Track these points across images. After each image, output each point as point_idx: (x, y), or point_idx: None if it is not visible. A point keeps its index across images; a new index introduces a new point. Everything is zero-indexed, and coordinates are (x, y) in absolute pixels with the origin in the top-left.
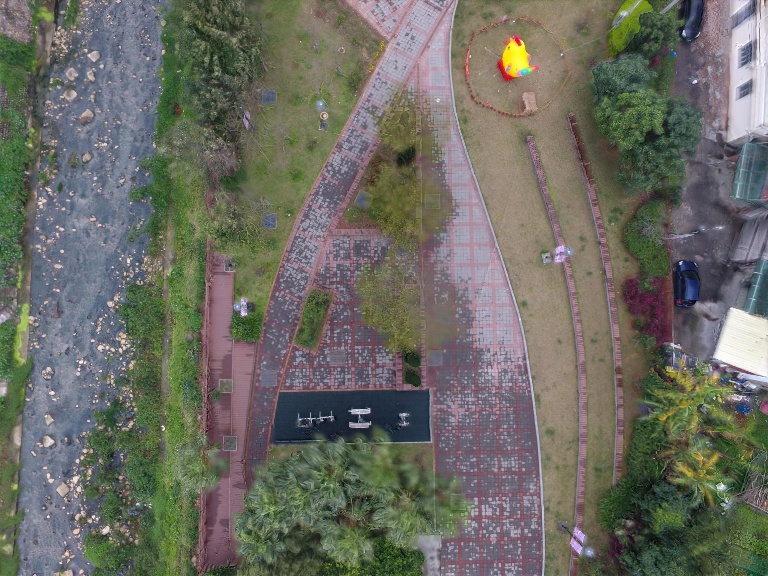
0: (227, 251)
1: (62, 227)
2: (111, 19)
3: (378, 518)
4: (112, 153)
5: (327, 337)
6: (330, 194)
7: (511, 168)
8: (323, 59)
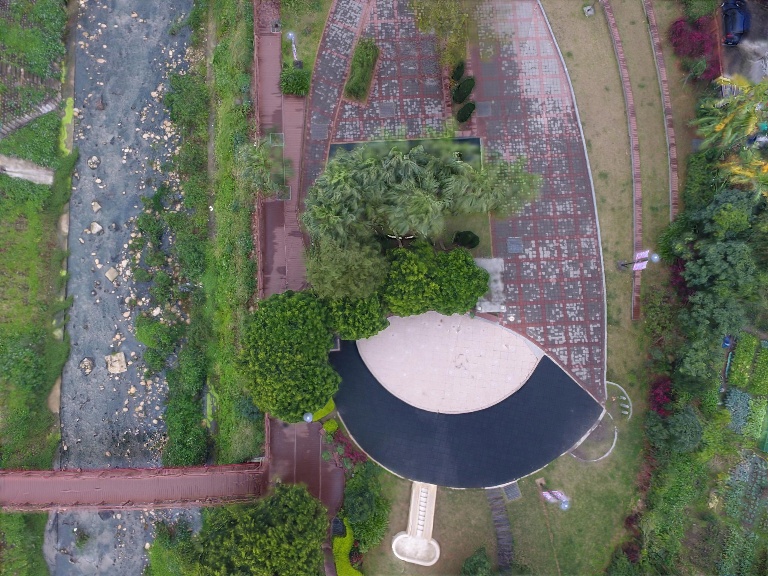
0: (272, 13)
1: (104, 24)
2: None
3: (448, 189)
4: None
5: (375, 91)
6: None
7: None
8: None
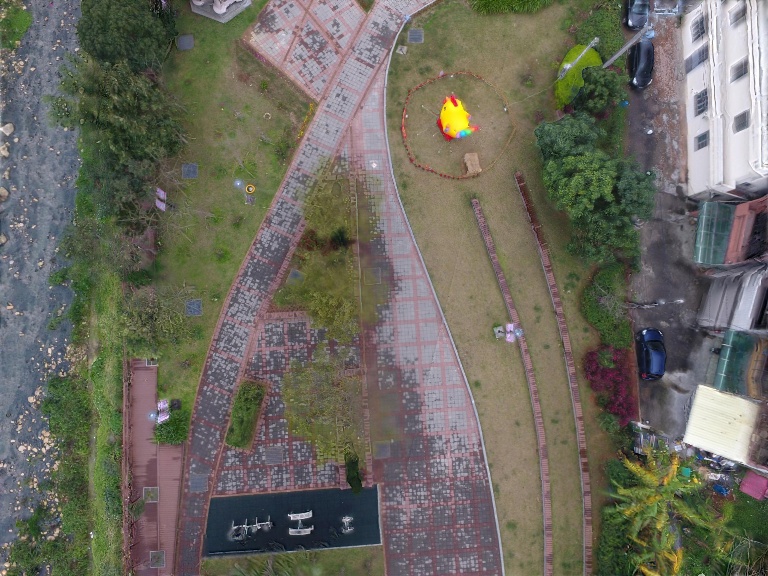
0: (148, 343)
1: None
2: (25, 88)
3: None
4: (29, 234)
5: (262, 433)
6: (260, 274)
7: (456, 235)
8: (247, 127)
